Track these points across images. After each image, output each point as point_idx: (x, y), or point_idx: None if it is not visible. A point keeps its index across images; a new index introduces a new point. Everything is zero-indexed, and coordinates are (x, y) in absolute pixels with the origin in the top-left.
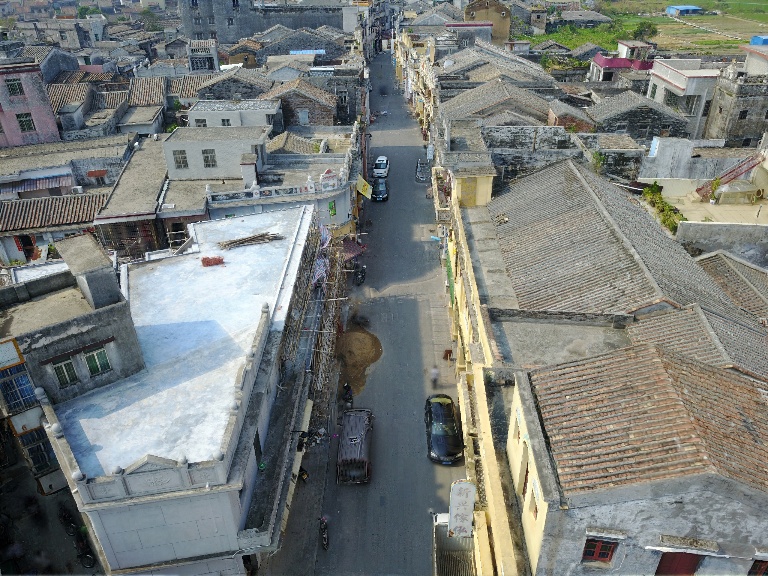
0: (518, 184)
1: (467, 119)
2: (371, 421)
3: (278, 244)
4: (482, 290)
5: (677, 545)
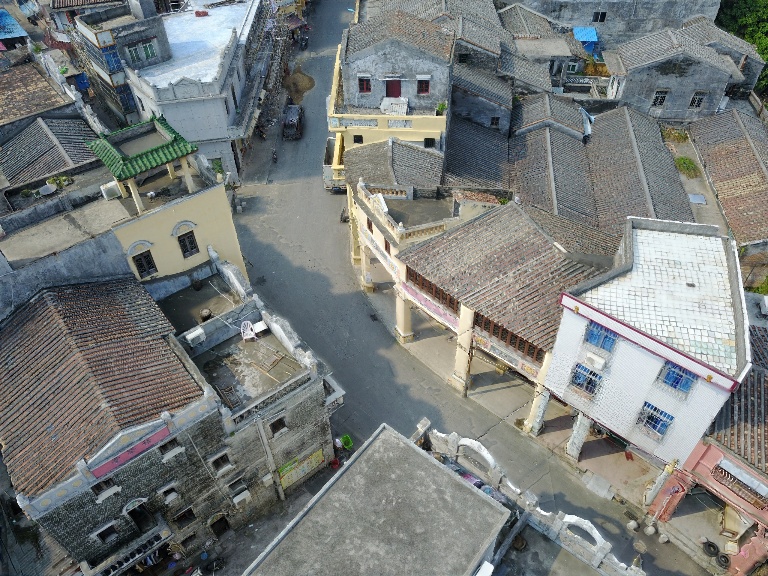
0: None
1: None
2: (302, 110)
3: (242, 5)
4: None
5: (387, 74)
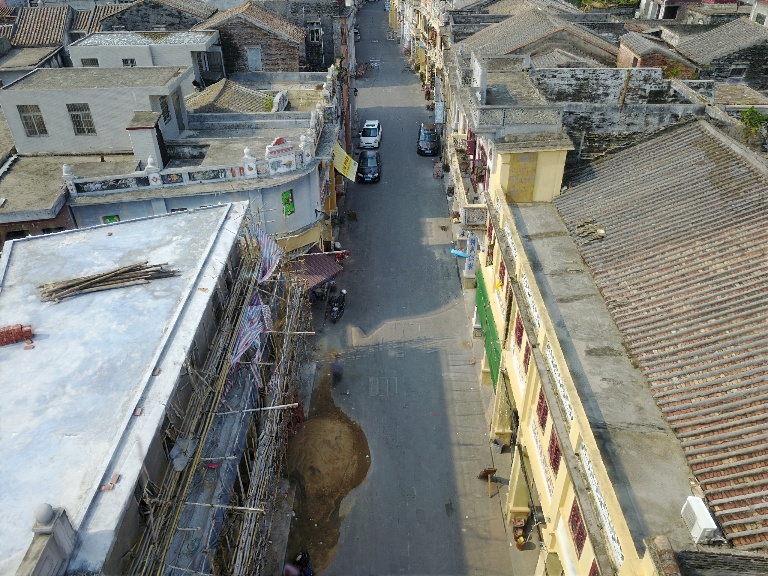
0: (608, 164)
1: (506, 56)
2: None
3: (161, 288)
4: (587, 407)
5: None
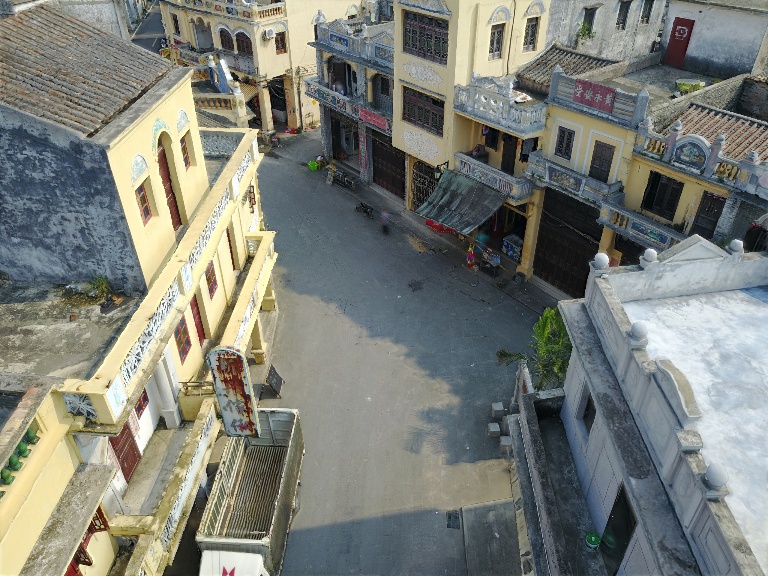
0: None
1: None
2: None
3: None
4: None
5: None
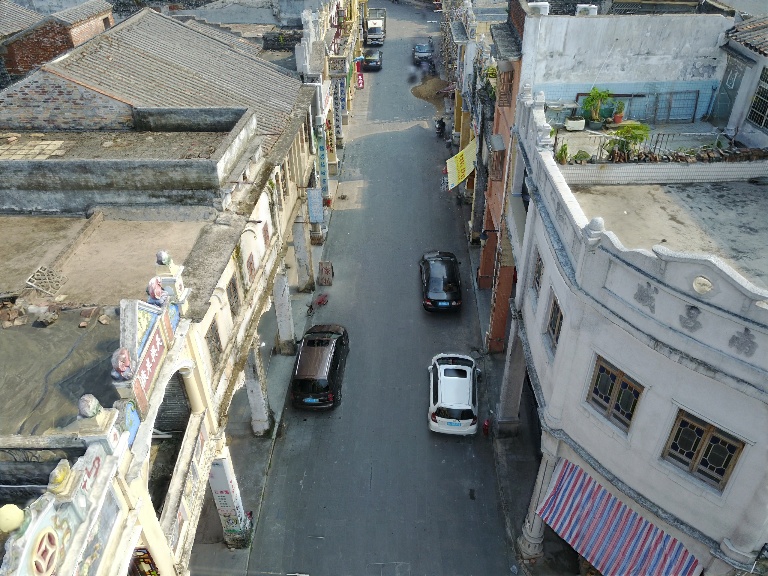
0: None
1: None
2: None
3: None
4: None
5: None
